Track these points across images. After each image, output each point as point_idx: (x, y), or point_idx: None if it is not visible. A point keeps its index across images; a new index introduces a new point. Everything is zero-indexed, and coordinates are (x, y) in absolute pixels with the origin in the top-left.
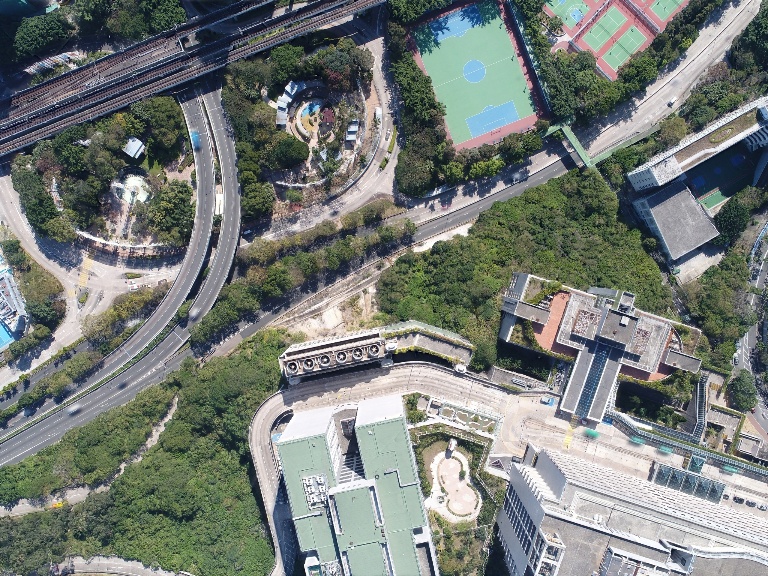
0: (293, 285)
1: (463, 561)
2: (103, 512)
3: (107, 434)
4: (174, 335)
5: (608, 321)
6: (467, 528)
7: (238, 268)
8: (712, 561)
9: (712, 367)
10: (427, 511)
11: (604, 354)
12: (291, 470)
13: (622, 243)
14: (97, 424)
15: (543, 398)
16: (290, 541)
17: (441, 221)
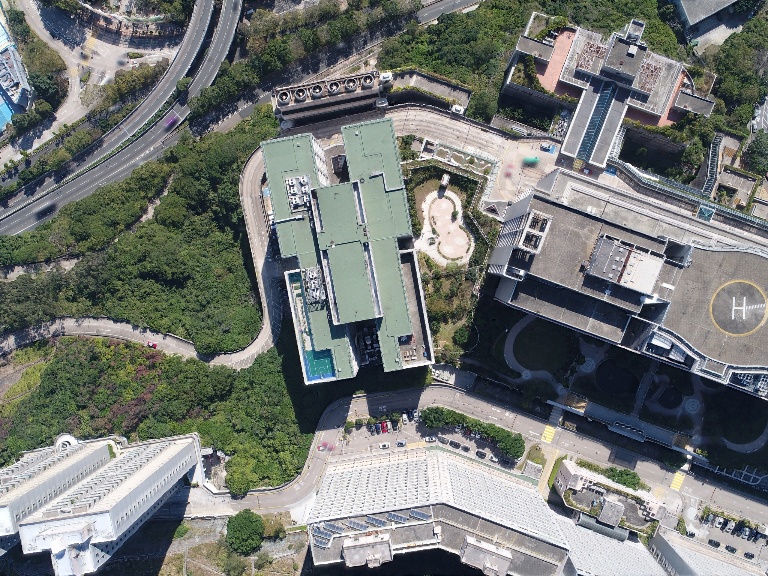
0: (293, 58)
1: (452, 304)
2: (94, 269)
3: (103, 206)
4: (173, 113)
5: (615, 51)
6: (457, 268)
7: (240, 49)
8: (712, 254)
9: (727, 128)
10: (417, 253)
11: (609, 91)
12: (274, 171)
13: (637, 11)
14: (94, 198)
15: (543, 143)
16: (278, 301)
17: (448, 2)
